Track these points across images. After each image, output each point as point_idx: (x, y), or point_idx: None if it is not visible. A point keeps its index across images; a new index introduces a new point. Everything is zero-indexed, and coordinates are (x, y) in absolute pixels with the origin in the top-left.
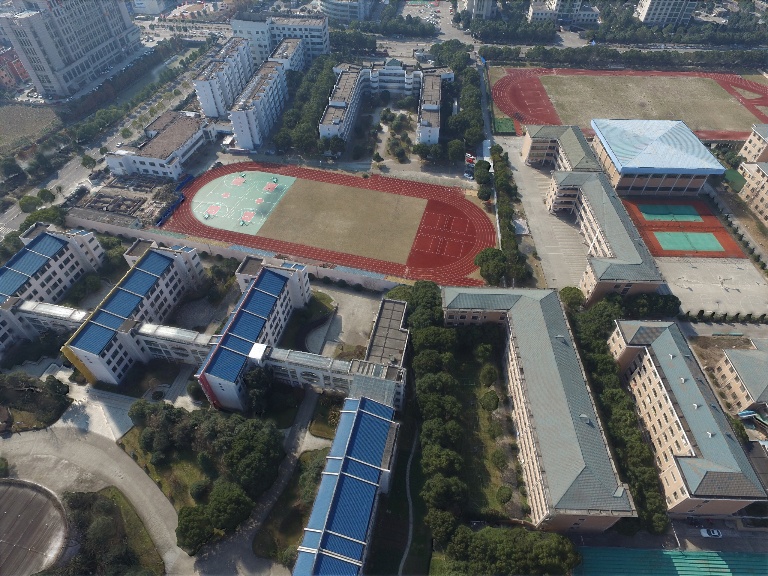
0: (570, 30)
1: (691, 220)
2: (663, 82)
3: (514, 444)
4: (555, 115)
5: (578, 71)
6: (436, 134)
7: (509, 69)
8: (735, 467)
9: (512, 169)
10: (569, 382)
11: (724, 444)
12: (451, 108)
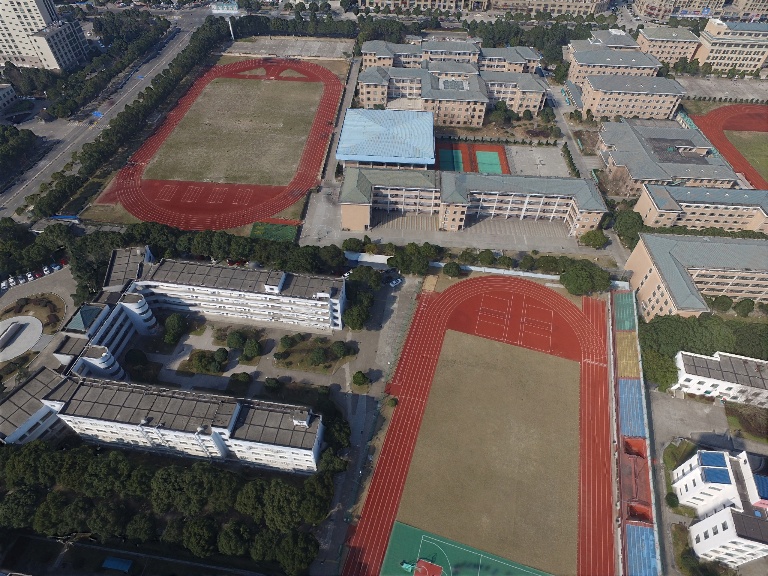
0: (14, 123)
1: (460, 155)
2: (210, 103)
3: (762, 304)
4: (258, 187)
5: (148, 146)
6: (344, 288)
7: (102, 199)
8: (766, 193)
9: (378, 243)
10: (752, 243)
11: (752, 192)
12: (248, 268)
